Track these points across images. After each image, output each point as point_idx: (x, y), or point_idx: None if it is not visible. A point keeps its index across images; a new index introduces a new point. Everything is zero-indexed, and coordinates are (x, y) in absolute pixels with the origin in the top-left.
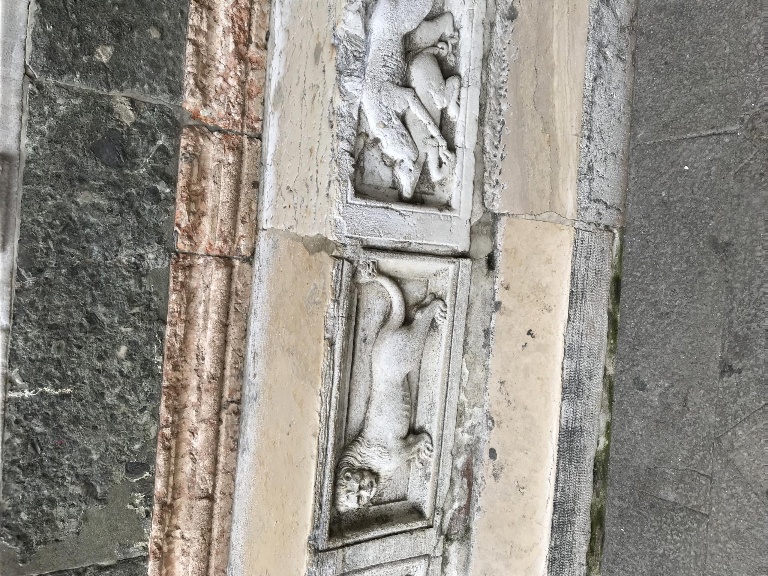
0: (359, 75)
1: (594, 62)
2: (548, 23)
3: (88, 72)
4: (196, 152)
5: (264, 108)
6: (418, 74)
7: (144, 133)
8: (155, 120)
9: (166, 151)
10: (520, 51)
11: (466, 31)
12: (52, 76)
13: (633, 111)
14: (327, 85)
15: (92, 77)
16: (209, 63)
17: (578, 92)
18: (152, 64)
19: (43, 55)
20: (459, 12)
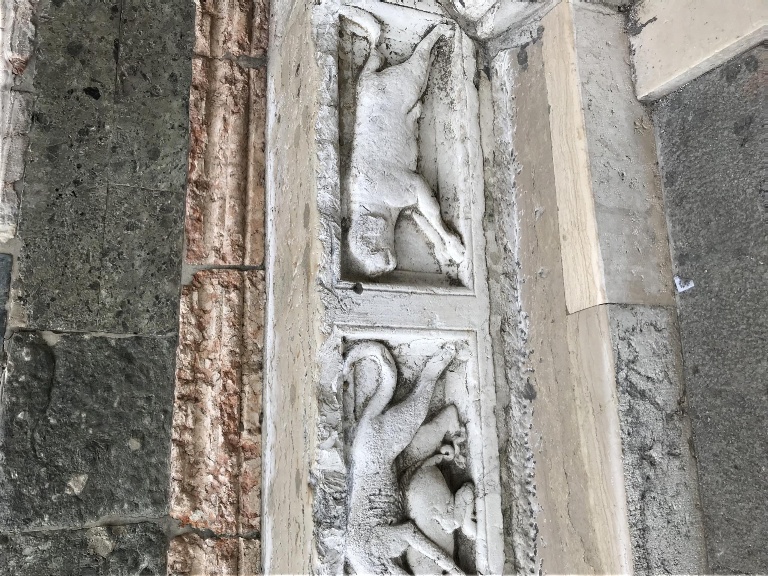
0: (340, 526)
1: (637, 476)
2: (572, 419)
3: (58, 512)
4: (185, 569)
5: (261, 502)
6: (417, 502)
7: (123, 562)
8: (137, 542)
9: (150, 575)
10: (544, 442)
11: (474, 427)
12: (17, 528)
13: (704, 516)
14: (306, 535)
15: (62, 516)
16: (198, 461)
17: (622, 520)
18: (132, 480)
19: (7, 508)
20: (464, 402)
